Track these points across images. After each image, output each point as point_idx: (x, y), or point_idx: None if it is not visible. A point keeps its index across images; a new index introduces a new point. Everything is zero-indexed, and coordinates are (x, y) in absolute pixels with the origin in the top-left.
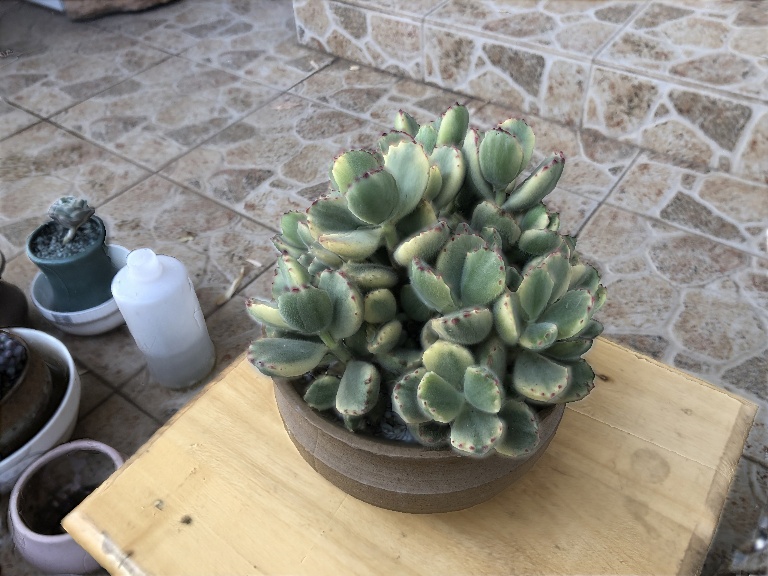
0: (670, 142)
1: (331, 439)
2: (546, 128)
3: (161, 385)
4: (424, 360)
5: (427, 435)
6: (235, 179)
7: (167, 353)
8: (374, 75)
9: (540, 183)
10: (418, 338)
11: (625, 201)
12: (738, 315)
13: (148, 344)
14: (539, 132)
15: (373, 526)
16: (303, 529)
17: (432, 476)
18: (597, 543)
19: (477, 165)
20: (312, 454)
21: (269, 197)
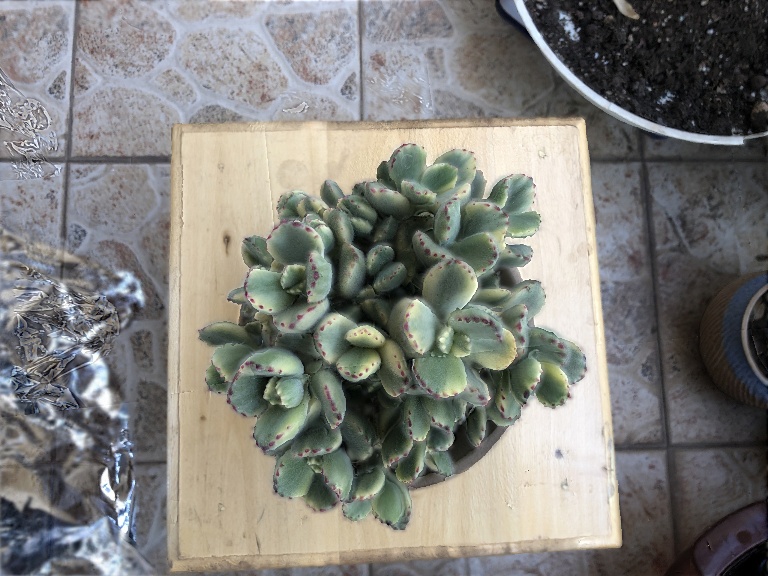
0: None
1: None
2: None
3: None
4: None
5: None
6: None
7: None
8: None
9: None
10: None
11: None
12: None
13: None
14: None
15: None
16: None
17: None
18: None
19: None
20: None
21: None
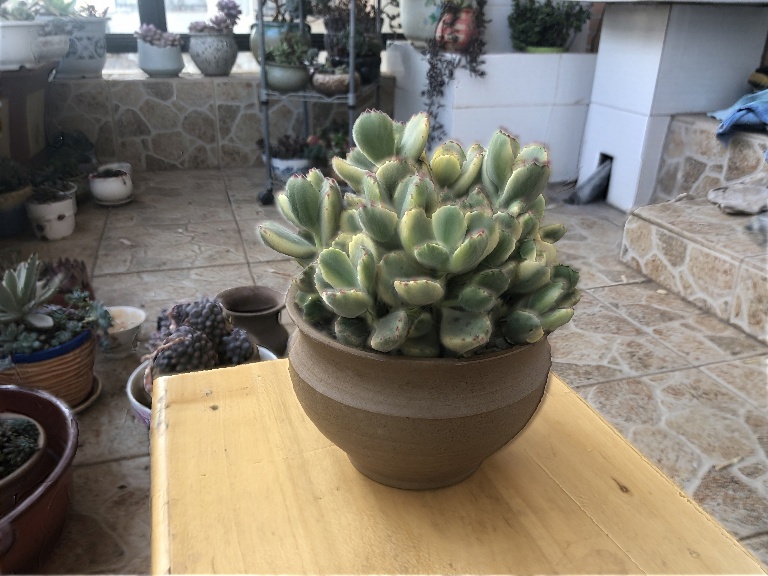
0: None
1: None
2: None
3: None
4: (349, 249)
5: (339, 327)
6: None
7: None
8: (678, 302)
9: (517, 177)
10: None
11: None
12: None
13: None
14: None
15: (322, 473)
16: (276, 449)
17: (343, 385)
18: None
19: (486, 164)
20: None
21: None
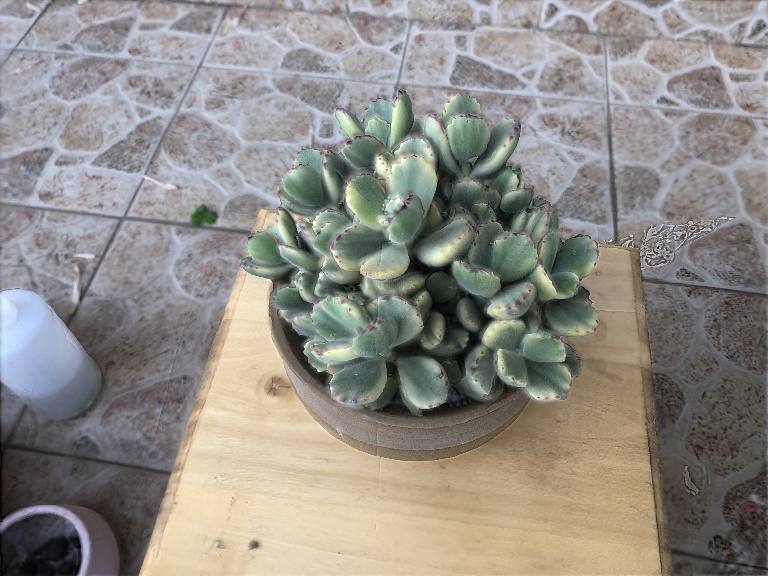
0: (434, 8)
1: (393, 427)
2: (316, 22)
3: (55, 420)
4: (487, 341)
5: (489, 394)
6: (11, 170)
7: (55, 388)
8: (110, 4)
9: (509, 151)
10: (455, 319)
11: (416, 78)
12: (543, 155)
13: (28, 387)
14: (311, 28)
15: (415, 472)
16: (360, 503)
17: (486, 420)
18: (583, 405)
19: (448, 150)
20: (376, 445)
21: (62, 178)
